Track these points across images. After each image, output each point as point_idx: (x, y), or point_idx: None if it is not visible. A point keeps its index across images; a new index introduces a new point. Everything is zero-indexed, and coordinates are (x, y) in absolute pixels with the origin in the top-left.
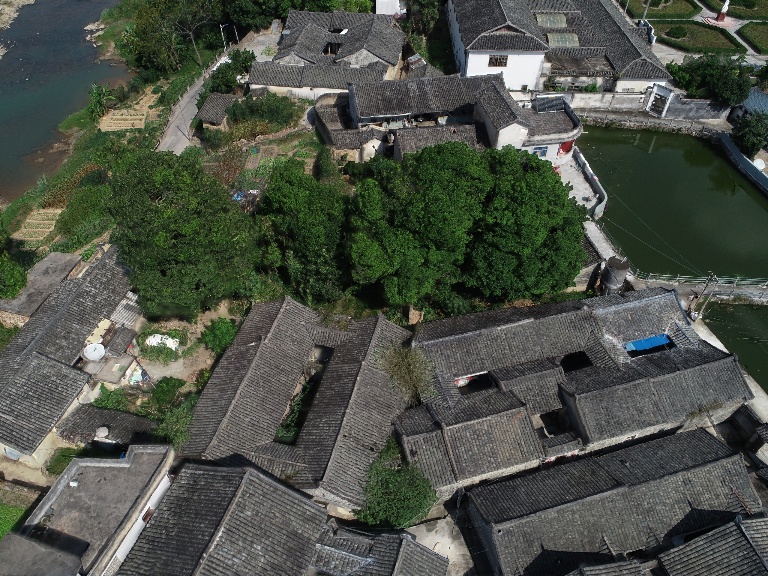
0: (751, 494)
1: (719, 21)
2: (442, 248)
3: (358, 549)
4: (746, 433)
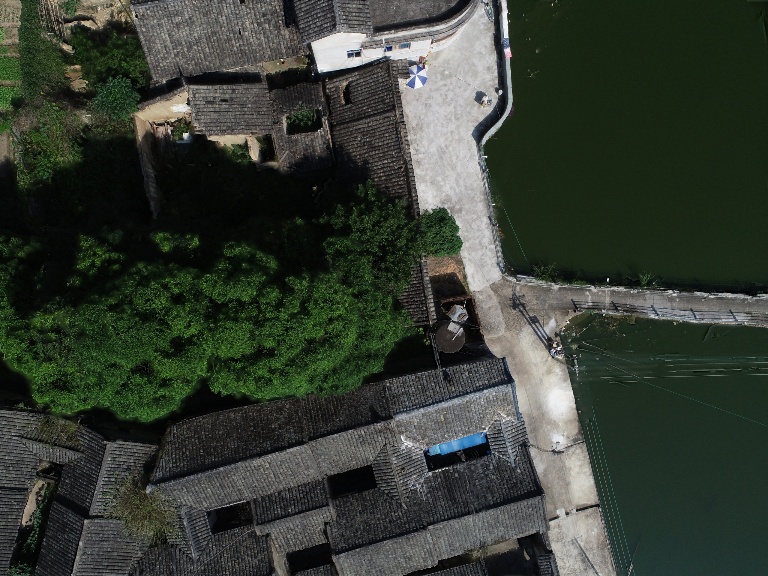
0: None
1: None
2: None
3: None
4: (537, 535)
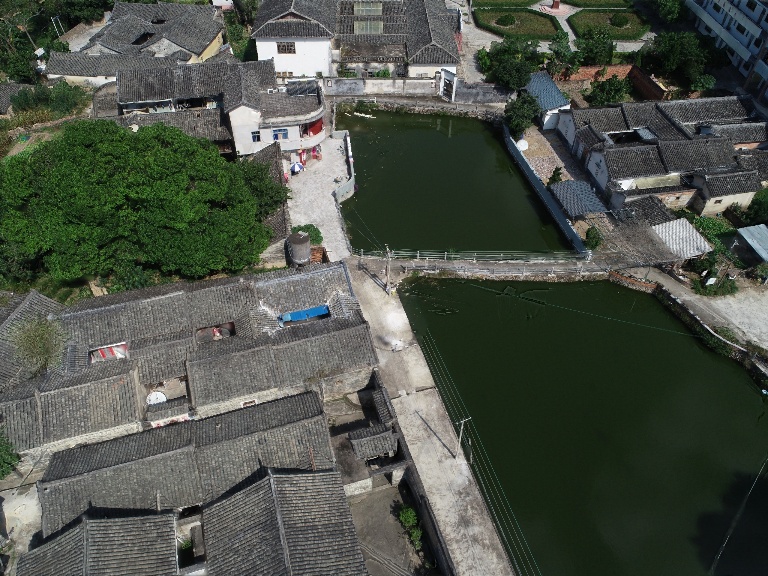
0: (327, 452)
1: (554, 9)
2: (87, 223)
3: None
4: None
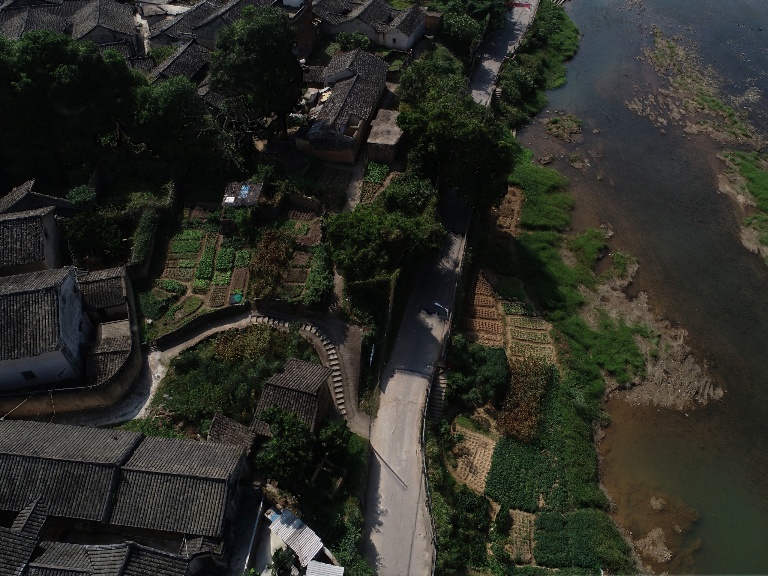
0: None
1: None
2: None
3: (184, 37)
4: None
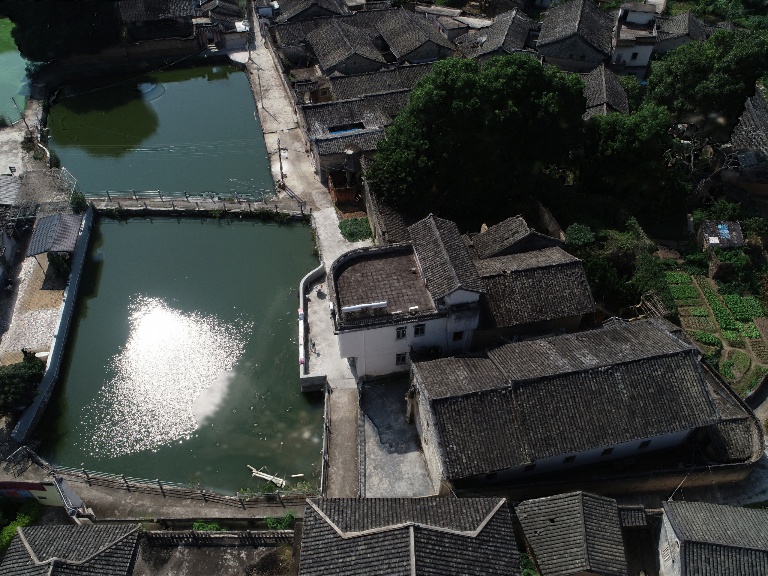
0: None
1: None
2: None
3: None
4: None
